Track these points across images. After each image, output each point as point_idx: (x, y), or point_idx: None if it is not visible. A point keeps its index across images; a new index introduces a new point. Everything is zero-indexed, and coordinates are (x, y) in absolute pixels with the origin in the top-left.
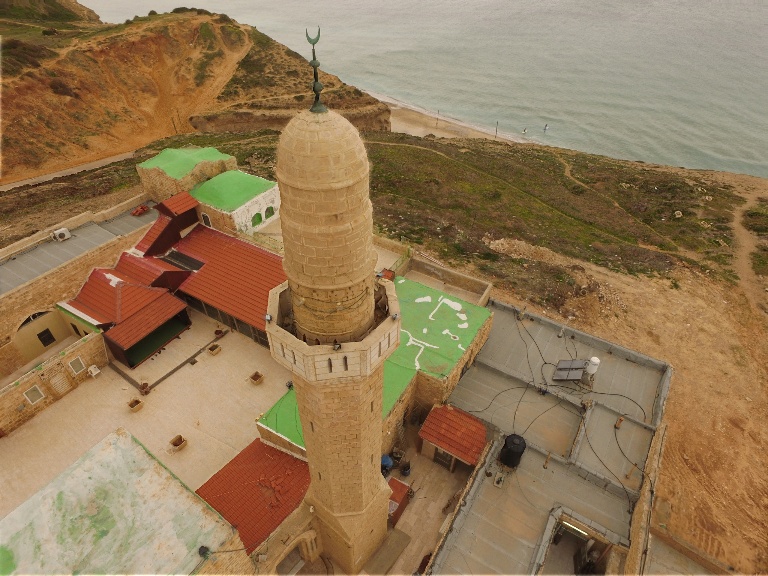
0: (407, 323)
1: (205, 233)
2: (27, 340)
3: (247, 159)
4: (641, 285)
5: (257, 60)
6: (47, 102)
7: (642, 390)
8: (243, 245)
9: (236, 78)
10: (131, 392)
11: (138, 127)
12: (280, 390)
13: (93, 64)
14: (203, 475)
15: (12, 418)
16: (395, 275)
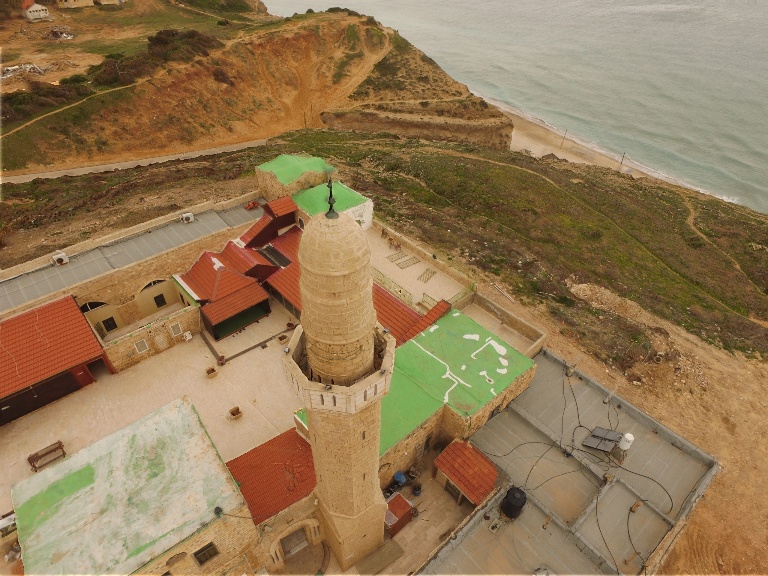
0: (449, 356)
1: (298, 235)
2: (146, 300)
3: (361, 160)
4: (734, 364)
5: (392, 63)
6: (208, 88)
7: (678, 480)
8: None
9: (370, 79)
10: (211, 360)
11: (276, 116)
12: None
13: (251, 56)
14: (248, 445)
15: (123, 361)
16: (454, 306)
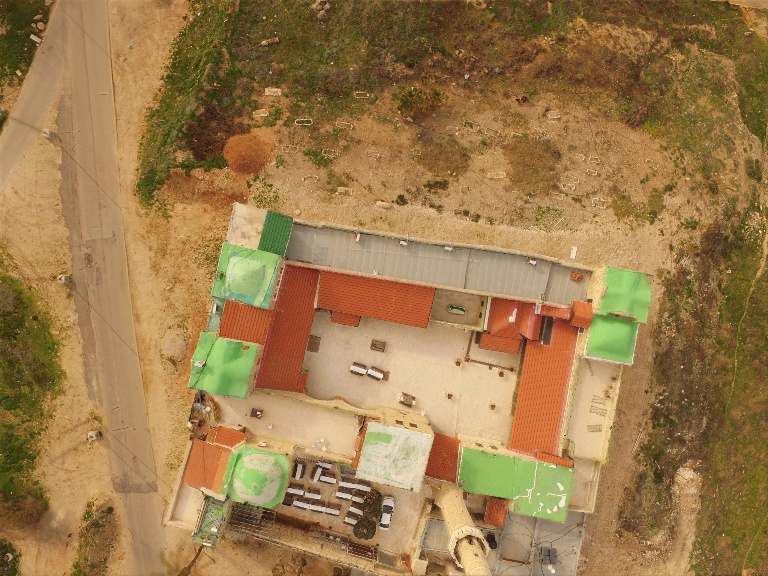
0: (540, 485)
1: (573, 331)
2: None
3: None
4: (679, 573)
5: None
6: None
7: None
8: (570, 363)
9: None
10: (464, 353)
11: None
12: (491, 420)
13: None
14: (442, 414)
15: None
16: None
